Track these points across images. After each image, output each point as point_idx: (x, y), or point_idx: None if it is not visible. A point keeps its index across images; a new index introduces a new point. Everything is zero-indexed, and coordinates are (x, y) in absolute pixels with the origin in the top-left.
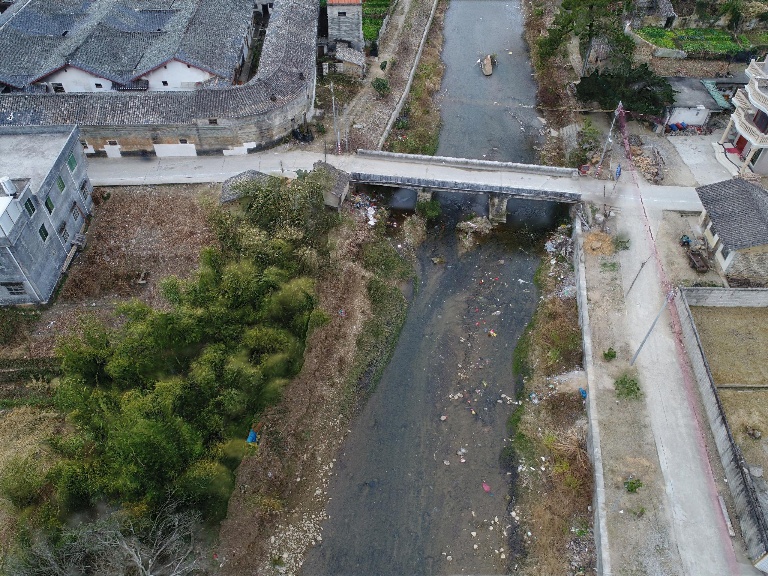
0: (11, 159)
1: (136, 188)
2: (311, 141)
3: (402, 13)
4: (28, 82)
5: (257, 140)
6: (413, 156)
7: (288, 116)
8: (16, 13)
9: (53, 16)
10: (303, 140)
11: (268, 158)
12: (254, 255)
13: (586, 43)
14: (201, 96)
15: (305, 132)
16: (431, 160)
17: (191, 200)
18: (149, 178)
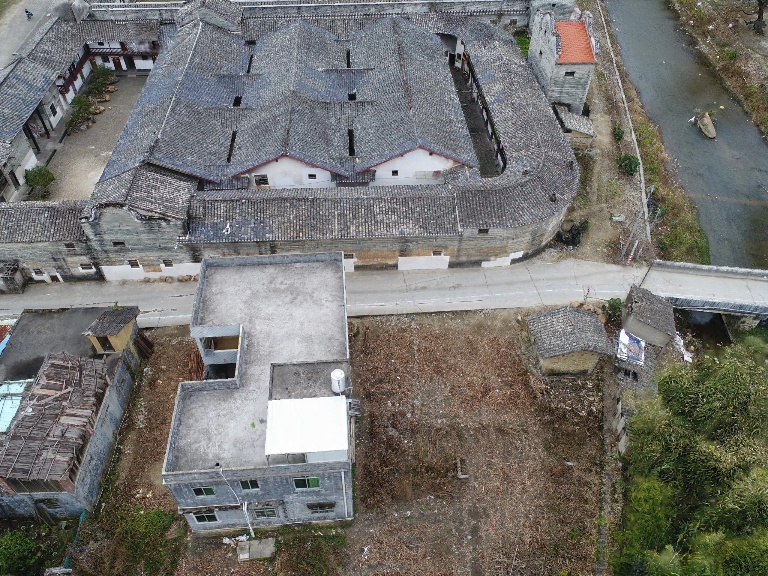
0: (274, 307)
1: (389, 319)
2: (578, 244)
3: None
4: (229, 175)
5: (526, 249)
6: (727, 269)
7: (560, 217)
8: (181, 77)
9: (218, 78)
10: (571, 243)
11: (539, 271)
12: (756, 508)
13: None
14: (466, 198)
15: (565, 231)
16: (749, 274)
17: (466, 336)
18: (402, 304)
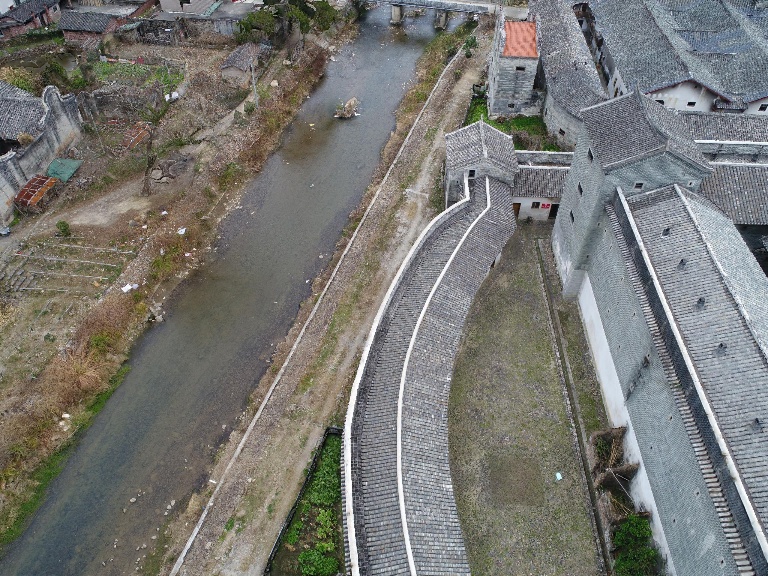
0: None
1: None
2: None
3: (436, 152)
4: None
5: None
6: (452, 4)
7: None
8: None
9: None
10: None
11: None
12: None
13: (230, 101)
14: None
15: None
16: (440, 5)
17: None
18: None
